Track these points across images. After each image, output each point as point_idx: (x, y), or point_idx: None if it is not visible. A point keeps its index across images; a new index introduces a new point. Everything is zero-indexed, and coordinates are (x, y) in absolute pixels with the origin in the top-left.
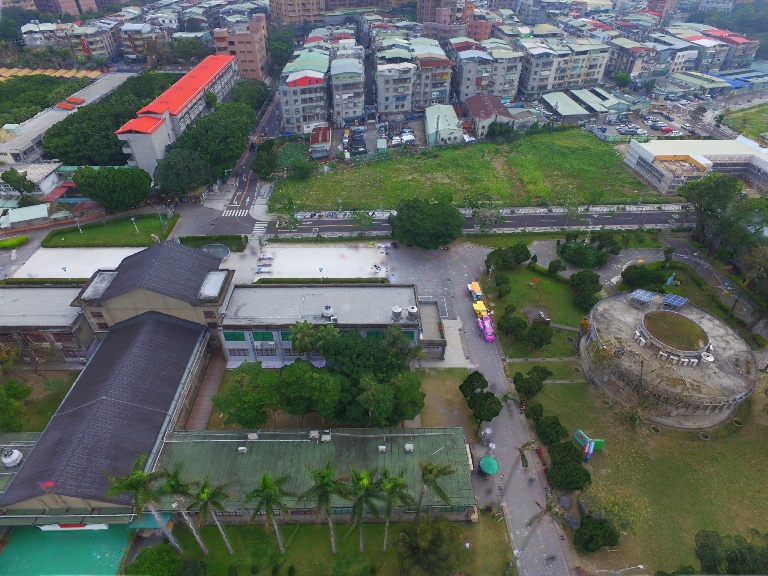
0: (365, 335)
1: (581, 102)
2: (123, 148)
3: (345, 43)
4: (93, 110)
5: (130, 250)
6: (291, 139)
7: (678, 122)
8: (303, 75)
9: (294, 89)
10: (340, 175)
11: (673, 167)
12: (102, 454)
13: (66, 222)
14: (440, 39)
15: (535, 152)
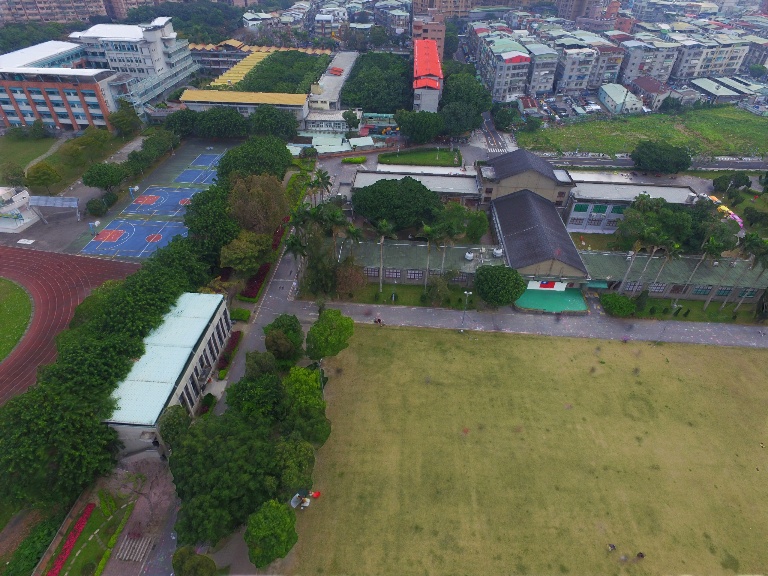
0: None
1: (726, 87)
2: (415, 100)
3: (521, 33)
4: (372, 74)
5: (442, 168)
6: (501, 105)
7: None
8: (516, 54)
9: (509, 65)
10: (558, 130)
11: None
12: (560, 249)
13: (382, 150)
14: (592, 32)
15: (706, 121)
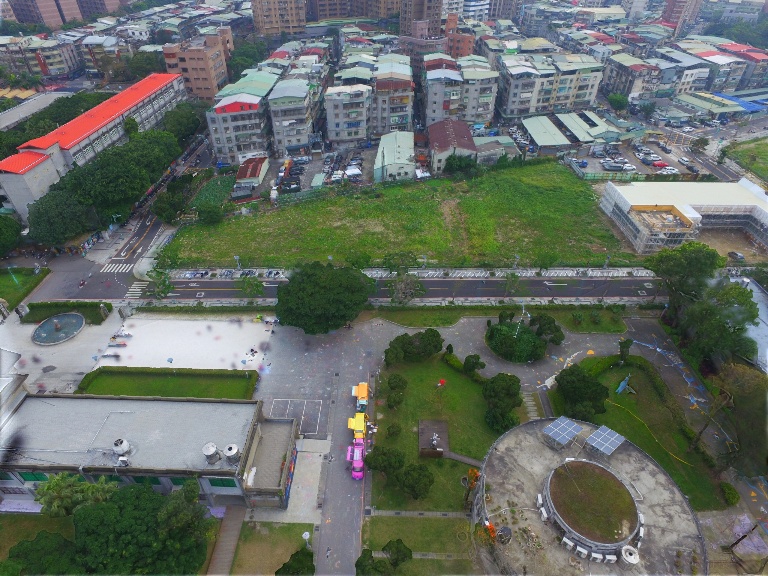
0: (168, 481)
1: (566, 128)
2: None
3: (304, 60)
4: None
5: None
6: (221, 171)
7: (676, 155)
8: (234, 100)
9: (223, 116)
10: (258, 219)
11: (652, 220)
12: None
13: None
14: (416, 55)
15: (496, 192)
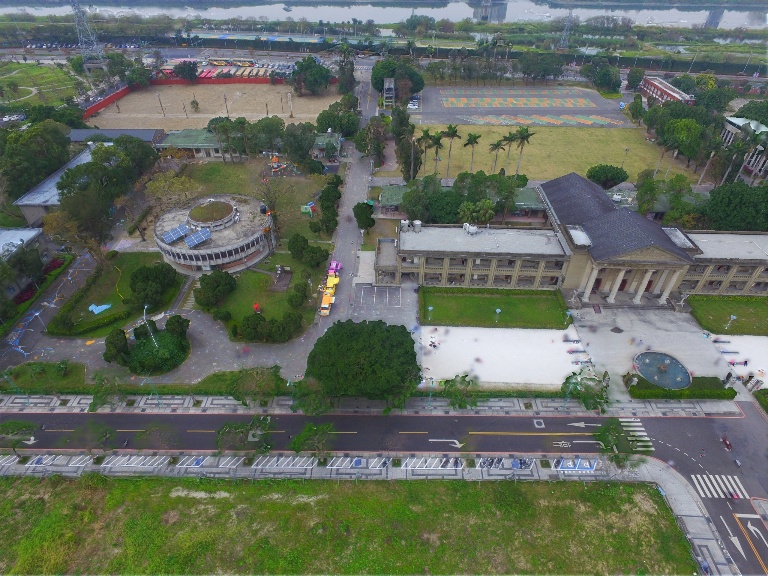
0: None
1: None
2: None
3: None
4: None
5: None
6: None
7: None
8: None
9: None
10: None
11: None
12: None
13: None
14: None
15: None
